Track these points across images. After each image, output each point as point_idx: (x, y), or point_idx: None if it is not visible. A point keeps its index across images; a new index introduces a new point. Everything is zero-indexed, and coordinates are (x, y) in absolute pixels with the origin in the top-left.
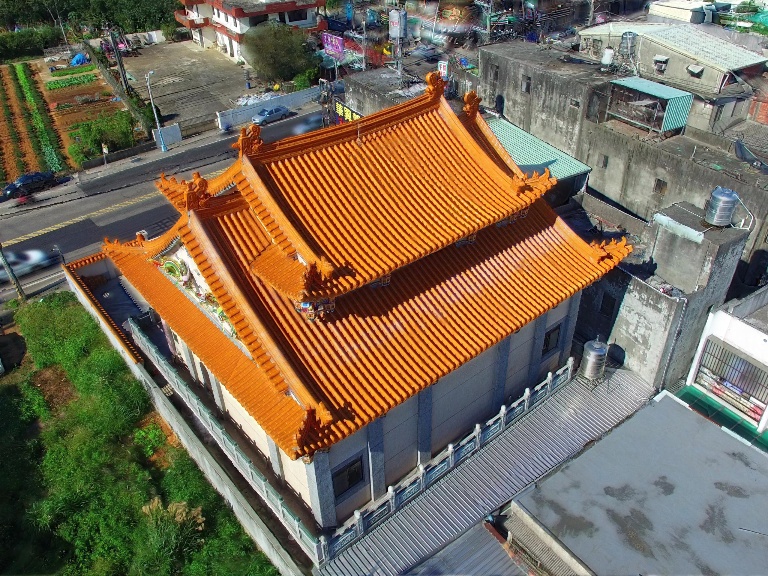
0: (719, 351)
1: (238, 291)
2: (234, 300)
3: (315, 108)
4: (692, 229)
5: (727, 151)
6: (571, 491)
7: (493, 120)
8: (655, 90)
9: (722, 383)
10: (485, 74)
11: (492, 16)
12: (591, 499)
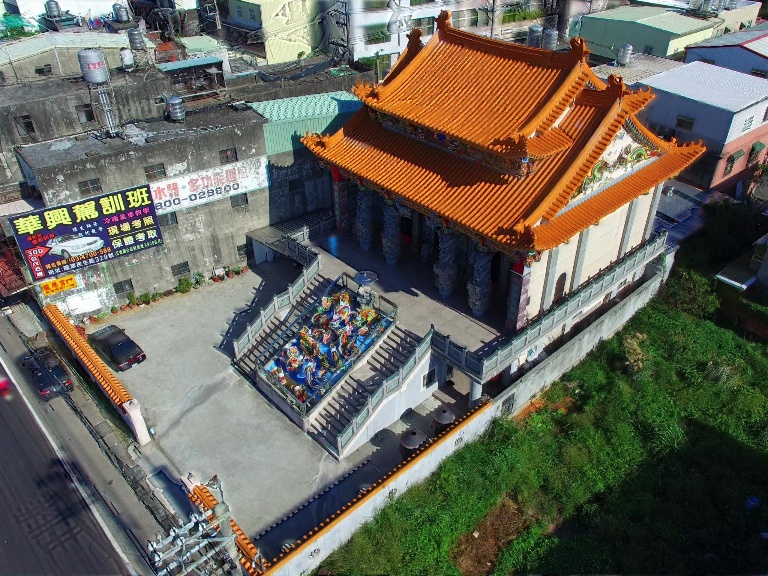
0: None
1: None
2: None
3: None
4: None
5: (256, 83)
6: None
7: None
8: (199, 62)
9: None
10: (8, 134)
11: None
12: None
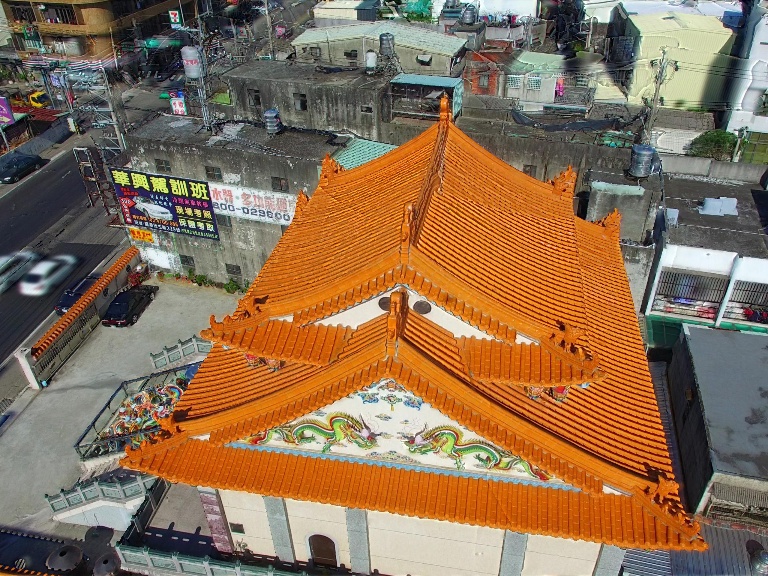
0: (672, 277)
1: (498, 409)
2: (493, 422)
3: (2, 190)
4: (630, 186)
5: (506, 121)
6: (733, 438)
7: (351, 142)
8: (434, 82)
9: (677, 301)
10: (242, 101)
11: (204, 40)
12: (750, 435)
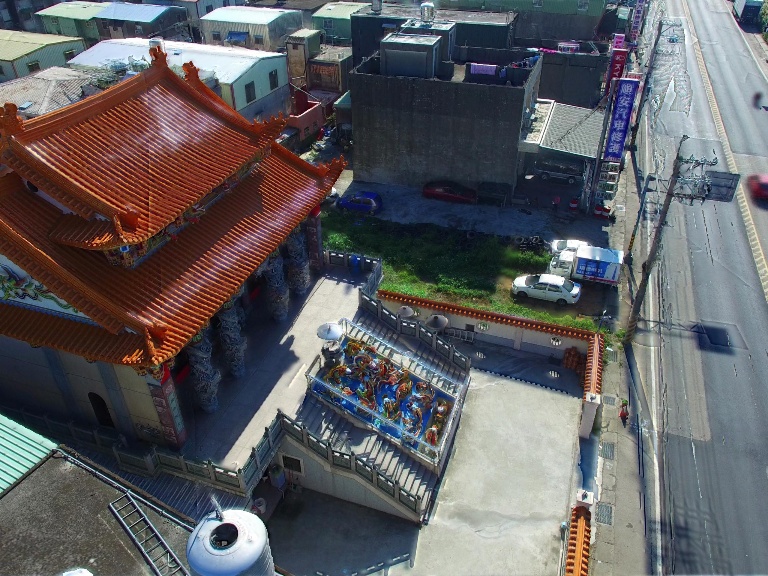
0: None
1: None
2: None
3: None
4: None
5: None
6: None
7: None
8: None
9: None
10: None
11: None
12: None
